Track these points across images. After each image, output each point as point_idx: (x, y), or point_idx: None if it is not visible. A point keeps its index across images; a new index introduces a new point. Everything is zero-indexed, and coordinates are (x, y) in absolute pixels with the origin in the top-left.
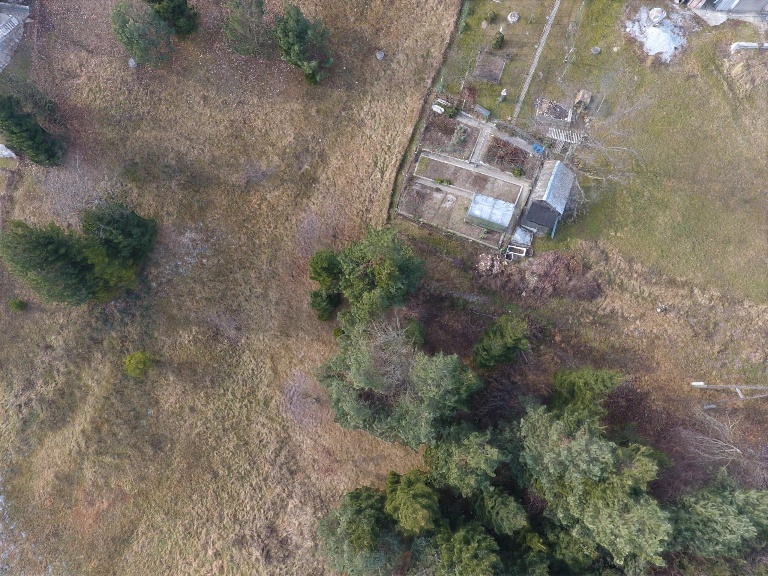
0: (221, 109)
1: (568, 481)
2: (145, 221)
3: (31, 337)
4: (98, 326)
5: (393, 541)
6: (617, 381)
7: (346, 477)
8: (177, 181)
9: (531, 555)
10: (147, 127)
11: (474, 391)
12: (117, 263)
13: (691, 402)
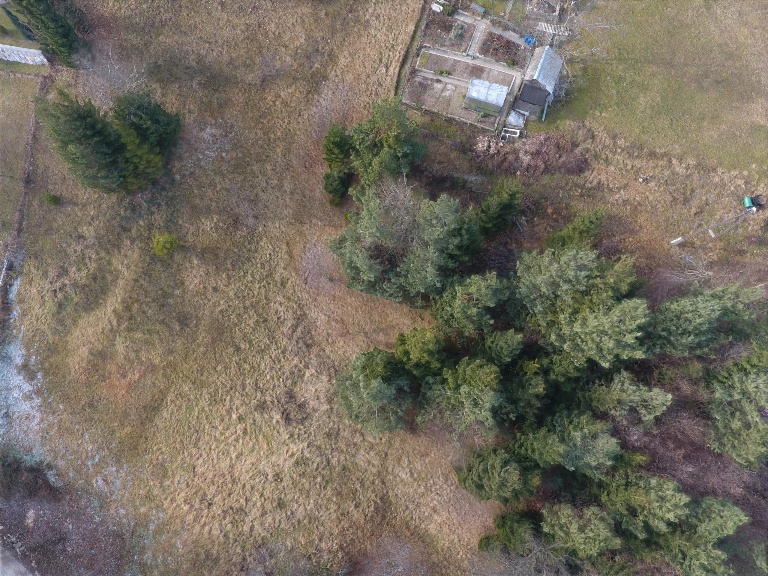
0: (237, 14)
1: (559, 304)
2: (169, 116)
3: (64, 229)
4: (127, 215)
5: (403, 382)
6: (601, 213)
7: (358, 348)
8: (198, 81)
9: (528, 374)
10: (169, 32)
11: (474, 249)
12: (146, 146)
13: (669, 244)
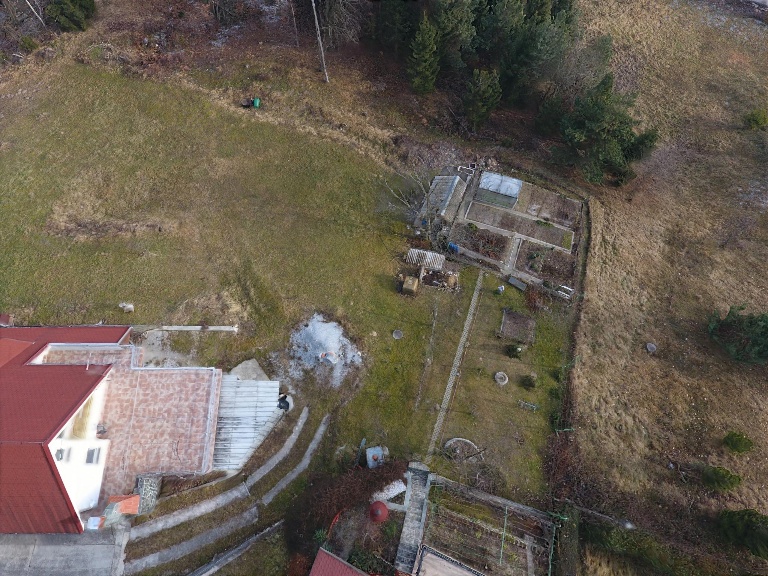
0: None
1: None
2: None
3: None
4: None
5: None
6: None
7: None
8: None
9: None
10: None
11: None
12: None
13: None
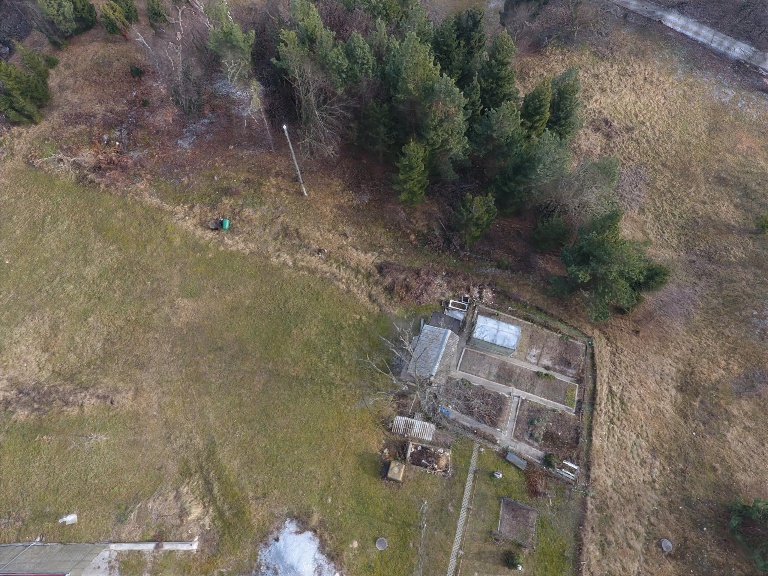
0: None
1: None
2: None
3: None
4: None
5: None
6: None
7: None
8: None
9: None
10: None
11: None
12: None
13: None
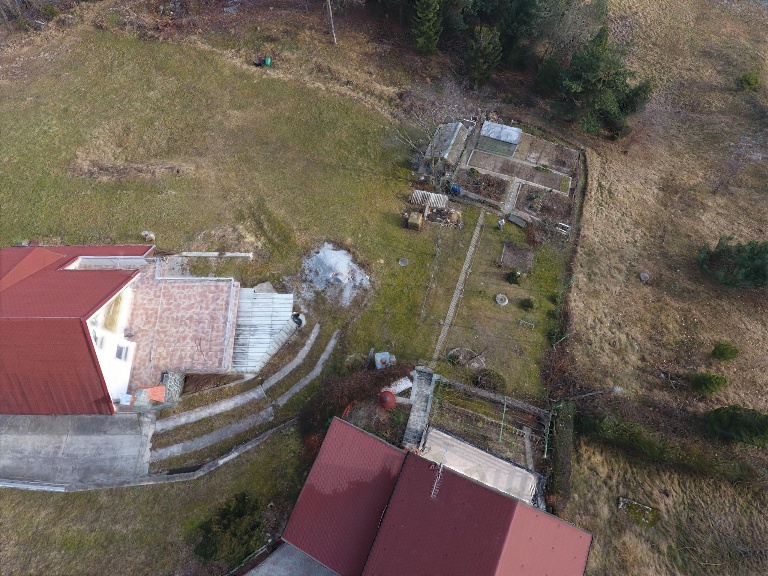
0: None
1: None
2: None
3: None
4: None
5: None
6: None
7: None
8: None
9: None
10: None
11: None
12: None
13: None
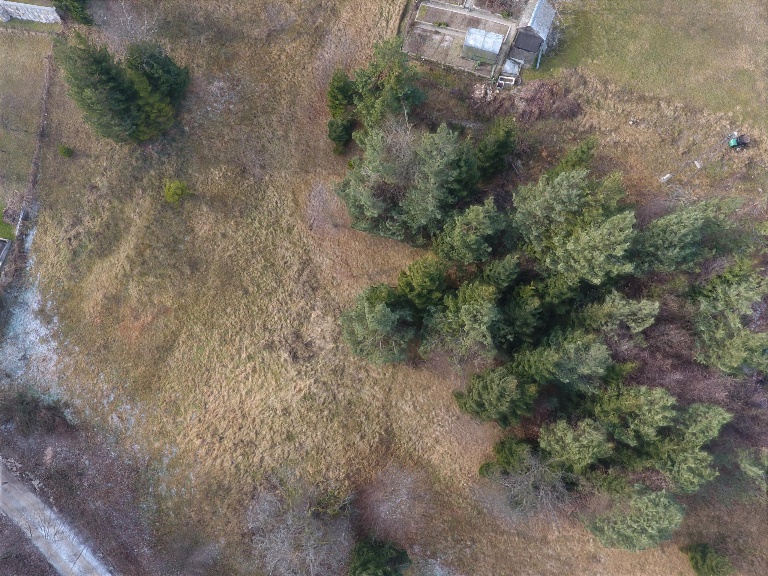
0: None
1: (553, 228)
2: (179, 69)
3: (78, 180)
4: (139, 164)
5: (406, 313)
6: (592, 141)
7: (362, 290)
8: (206, 36)
9: (524, 297)
10: None
11: None
12: (158, 95)
13: None
